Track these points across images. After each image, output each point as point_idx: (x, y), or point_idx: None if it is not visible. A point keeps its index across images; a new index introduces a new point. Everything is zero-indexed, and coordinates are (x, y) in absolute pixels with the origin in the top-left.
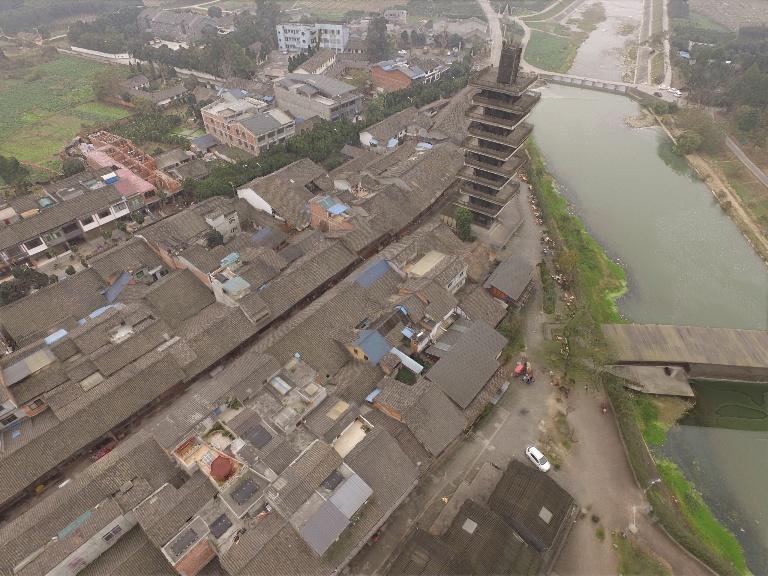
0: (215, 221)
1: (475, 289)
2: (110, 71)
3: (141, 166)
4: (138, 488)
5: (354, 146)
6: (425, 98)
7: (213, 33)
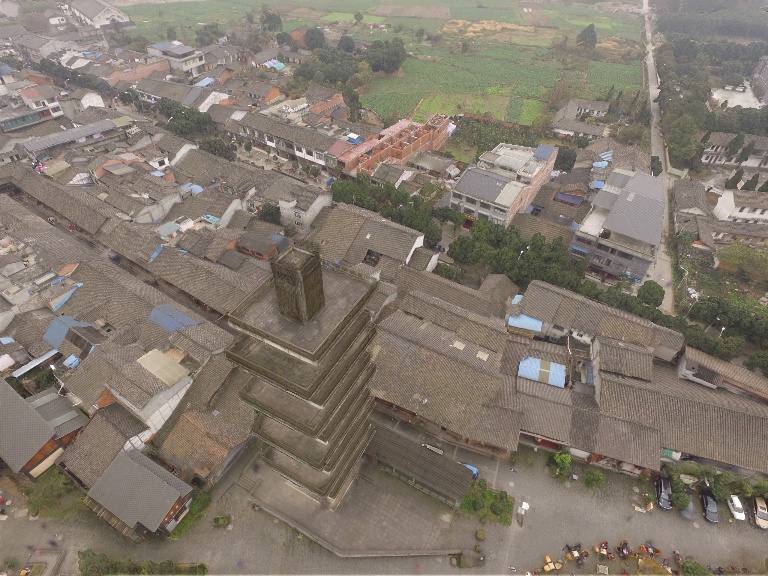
0: (281, 202)
1: (122, 434)
2: (623, 90)
3: (389, 148)
4: (3, 235)
5: (517, 287)
6: (759, 360)
7: (695, 93)
